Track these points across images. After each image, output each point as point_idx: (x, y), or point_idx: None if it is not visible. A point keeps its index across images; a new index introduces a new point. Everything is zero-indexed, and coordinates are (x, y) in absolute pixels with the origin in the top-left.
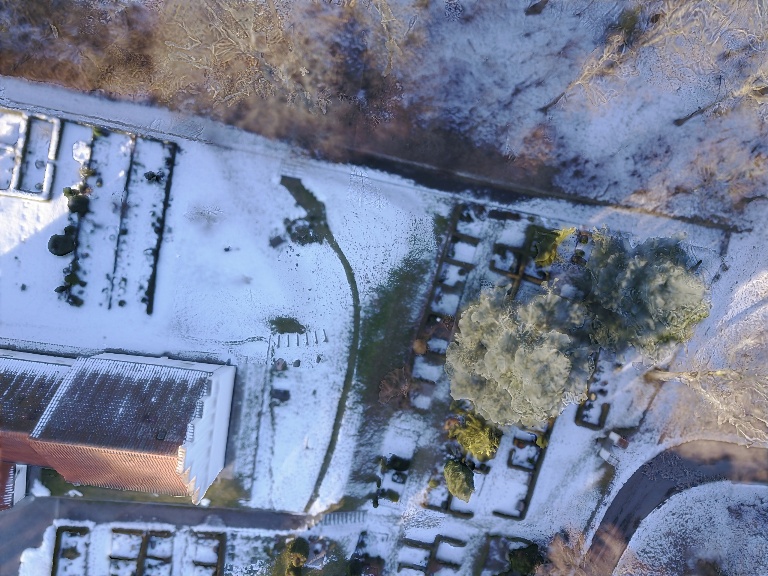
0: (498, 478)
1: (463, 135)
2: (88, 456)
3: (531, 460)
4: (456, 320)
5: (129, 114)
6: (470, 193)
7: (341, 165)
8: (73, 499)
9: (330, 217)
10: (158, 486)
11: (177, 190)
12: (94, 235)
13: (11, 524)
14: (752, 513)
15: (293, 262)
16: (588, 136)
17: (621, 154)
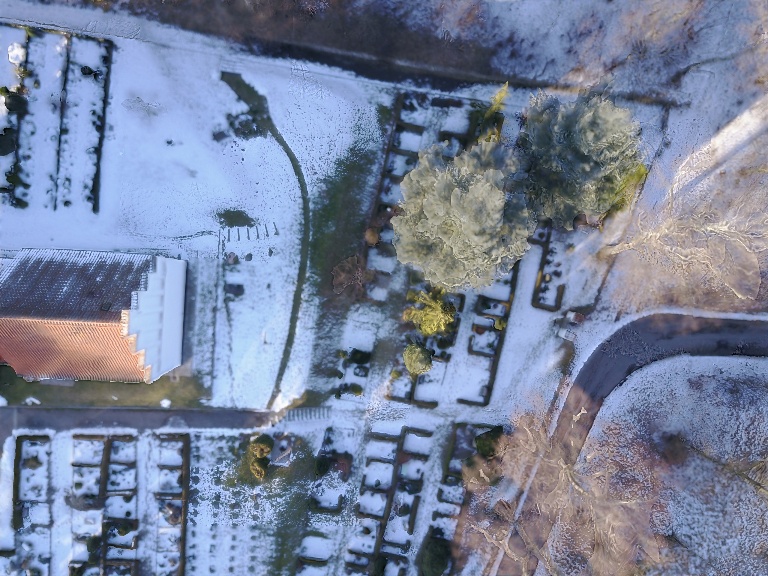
0: (460, 365)
1: (399, 20)
2: (32, 331)
3: (491, 344)
4: None
5: (64, 17)
6: (412, 82)
7: (281, 60)
8: (31, 408)
9: (273, 110)
10: (110, 371)
11: (116, 88)
12: (35, 137)
13: None
14: (712, 383)
15: (238, 157)
16: (522, 15)
17: (556, 31)
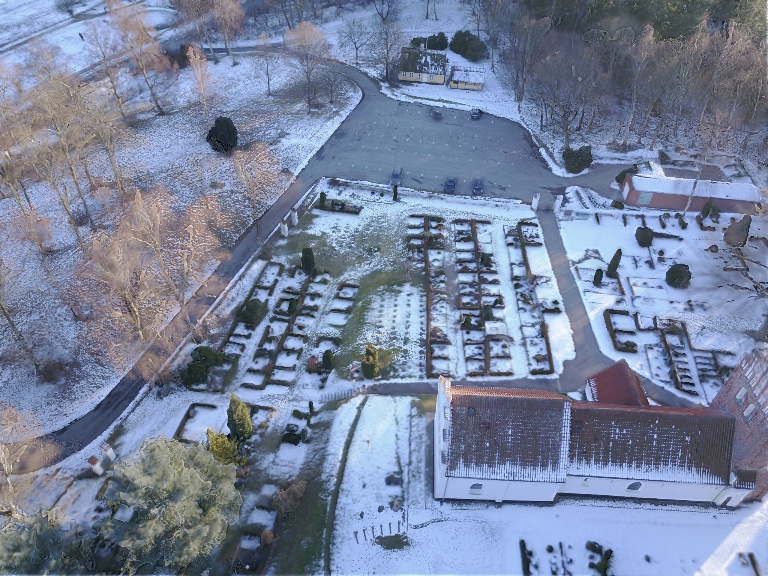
0: None
1: None
2: None
3: None
4: (230, 570)
5: None
6: None
7: None
8: None
9: None
10: None
11: None
12: None
13: (590, 373)
14: None
15: None
16: None
17: None
